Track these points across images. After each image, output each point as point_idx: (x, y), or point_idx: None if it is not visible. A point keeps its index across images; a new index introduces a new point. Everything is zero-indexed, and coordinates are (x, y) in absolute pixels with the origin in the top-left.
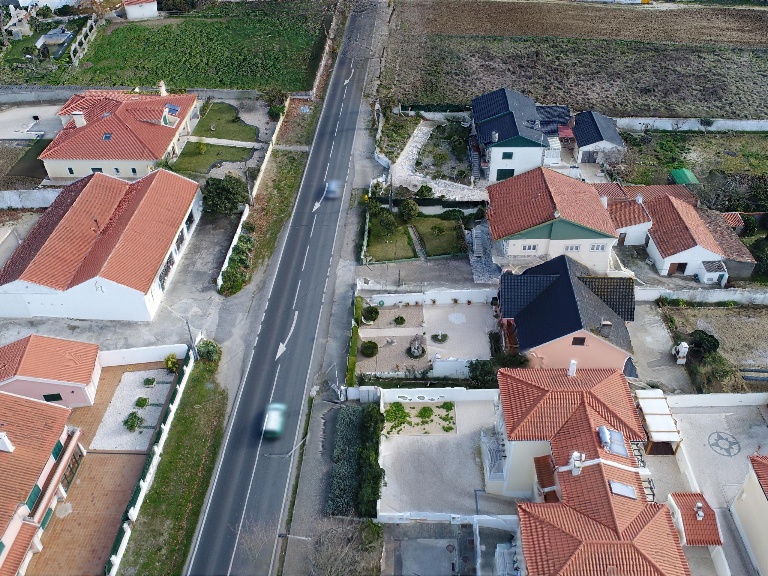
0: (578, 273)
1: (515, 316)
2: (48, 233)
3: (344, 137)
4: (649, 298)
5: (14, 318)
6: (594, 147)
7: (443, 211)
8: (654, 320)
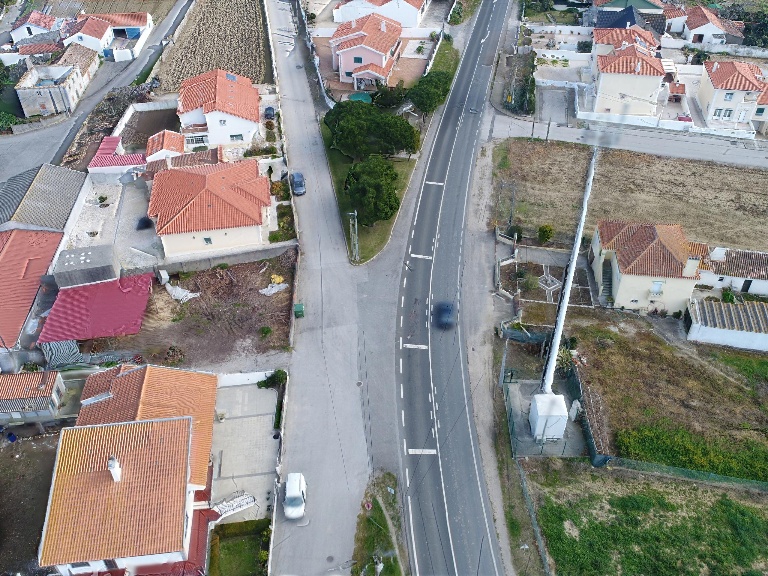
0: None
1: None
2: None
3: None
4: (678, 47)
5: None
6: None
7: (567, 9)
8: (679, 54)
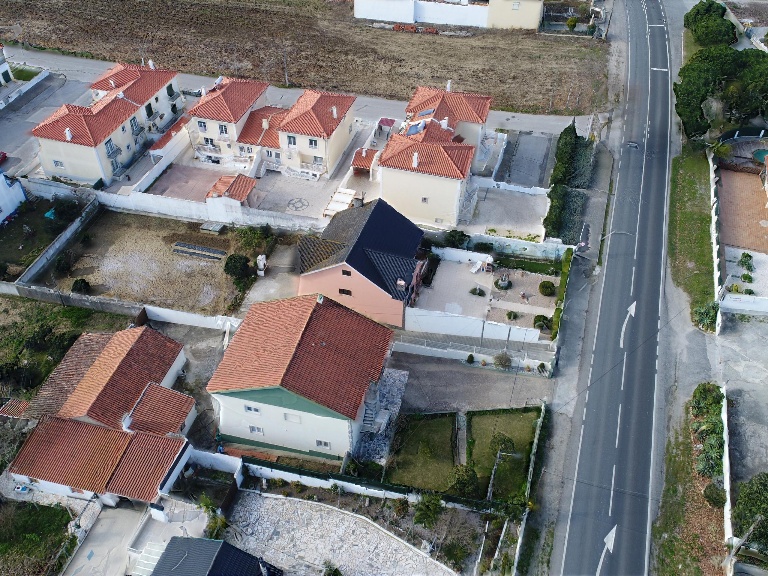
0: None
1: None
2: None
3: None
4: None
5: None
6: None
7: None
8: None
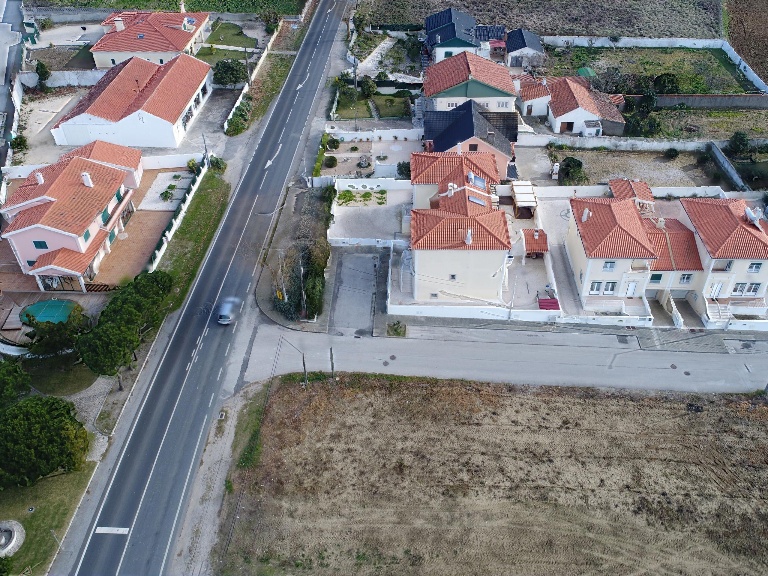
0: (480, 110)
1: (434, 139)
2: (102, 90)
3: (324, 46)
4: (541, 144)
5: (79, 146)
6: (520, 53)
7: (396, 91)
8: (542, 156)
